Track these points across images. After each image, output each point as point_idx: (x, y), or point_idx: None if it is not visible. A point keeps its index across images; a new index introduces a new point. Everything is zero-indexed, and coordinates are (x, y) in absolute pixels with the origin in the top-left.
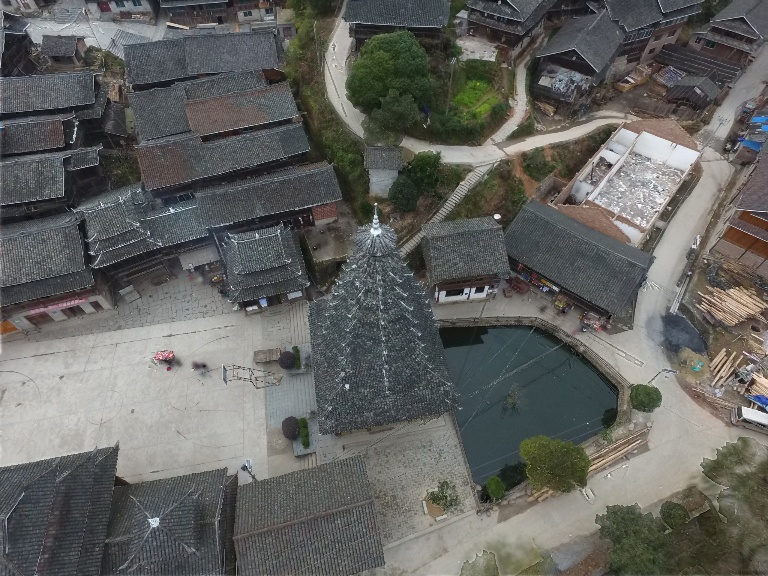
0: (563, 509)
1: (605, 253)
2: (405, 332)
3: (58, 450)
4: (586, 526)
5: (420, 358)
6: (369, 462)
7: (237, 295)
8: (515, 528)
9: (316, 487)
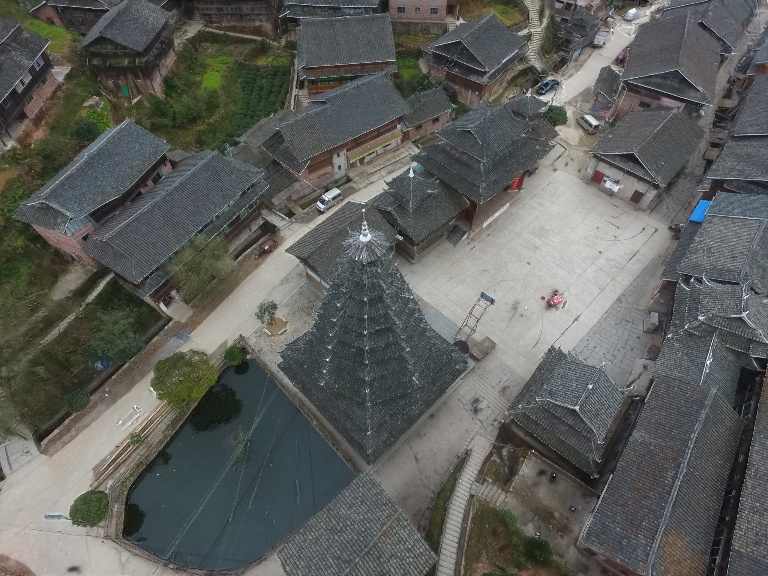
0: None
1: None
2: None
3: (540, 225)
4: None
5: None
6: None
7: None
8: (213, 343)
9: None
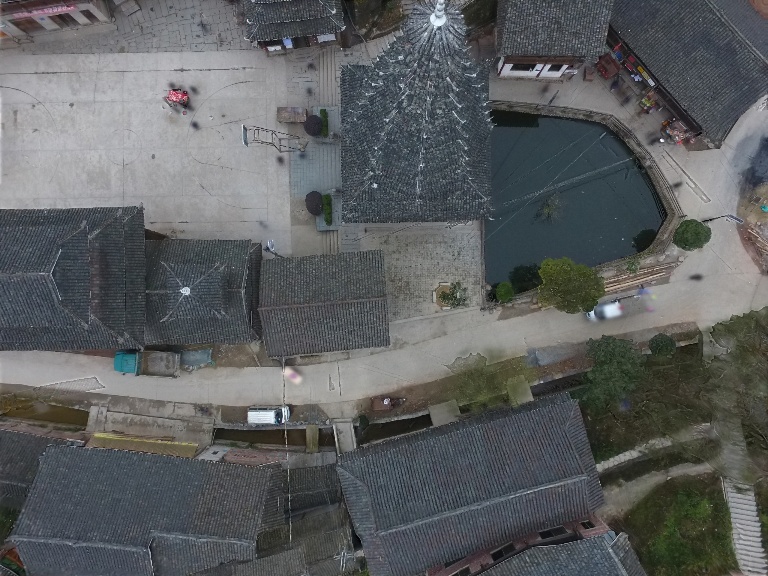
0: (561, 319)
1: (740, 45)
2: (450, 143)
3: (87, 186)
4: (577, 336)
5: (461, 170)
6: (389, 248)
7: (255, 31)
8: (512, 327)
9: (335, 275)
